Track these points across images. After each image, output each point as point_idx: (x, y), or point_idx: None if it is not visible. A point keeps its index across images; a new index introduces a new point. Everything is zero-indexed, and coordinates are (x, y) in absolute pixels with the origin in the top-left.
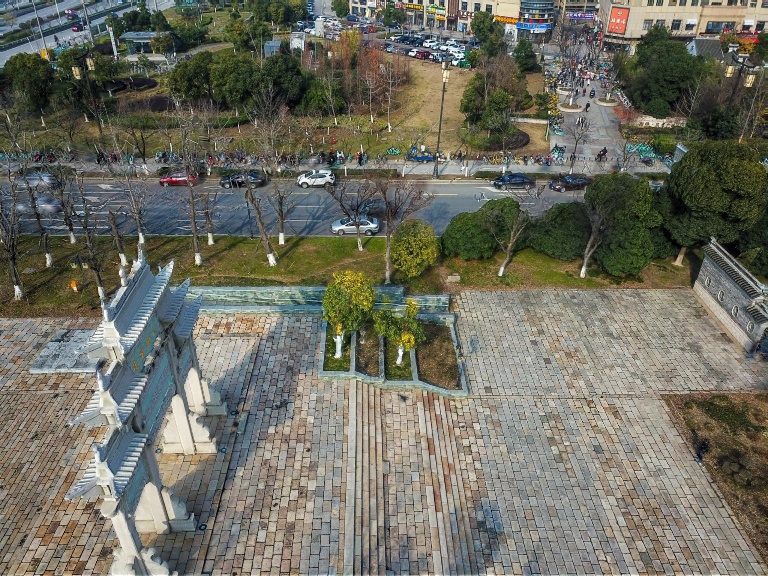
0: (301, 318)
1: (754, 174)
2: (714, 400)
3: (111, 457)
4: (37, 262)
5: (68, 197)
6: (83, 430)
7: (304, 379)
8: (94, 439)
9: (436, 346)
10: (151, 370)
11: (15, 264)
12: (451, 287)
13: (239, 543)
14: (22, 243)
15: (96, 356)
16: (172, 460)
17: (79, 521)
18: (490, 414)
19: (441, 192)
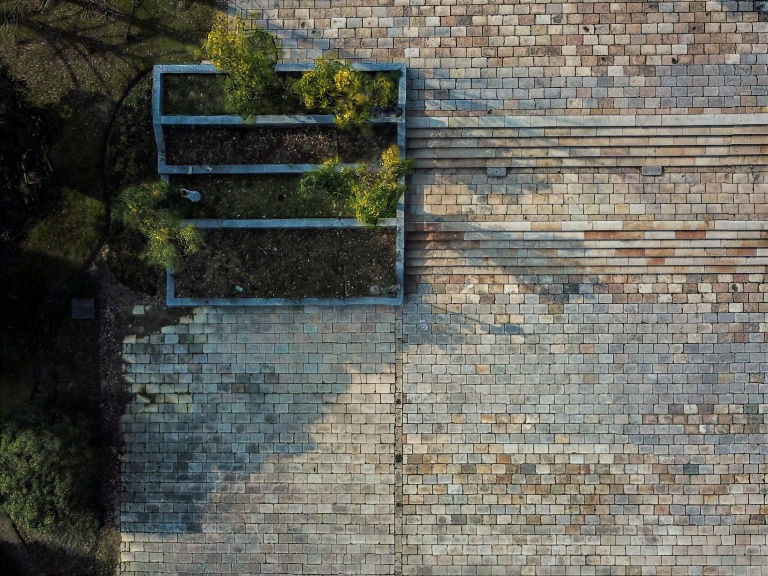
0: None
1: None
2: None
3: None
4: None
5: None
6: None
7: None
8: None
9: None
10: None
11: None
12: None
13: None
14: None
15: None
16: None
17: None
18: (760, 331)
19: None
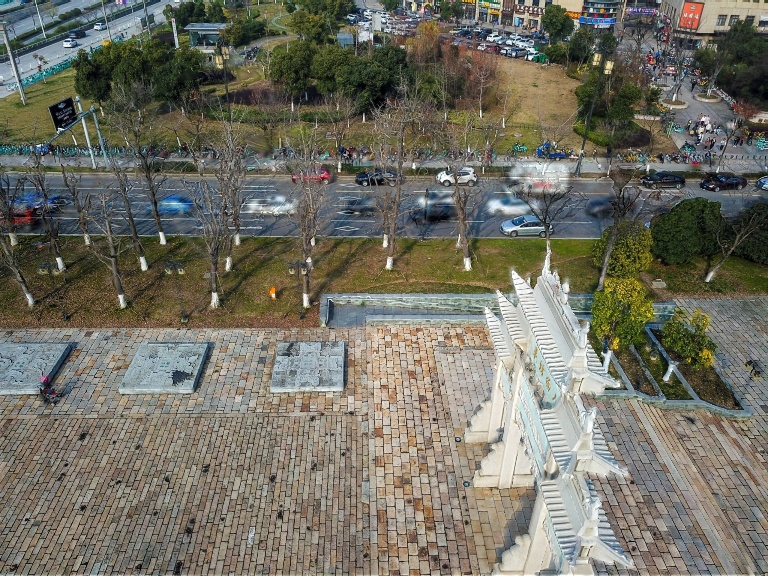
0: None
1: None
2: None
3: None
4: None
5: (238, 195)
6: (365, 459)
7: None
8: (384, 470)
9: None
10: None
11: (217, 269)
12: (660, 294)
13: None
14: (184, 245)
15: None
16: (488, 495)
17: (421, 570)
18: None
19: (591, 191)
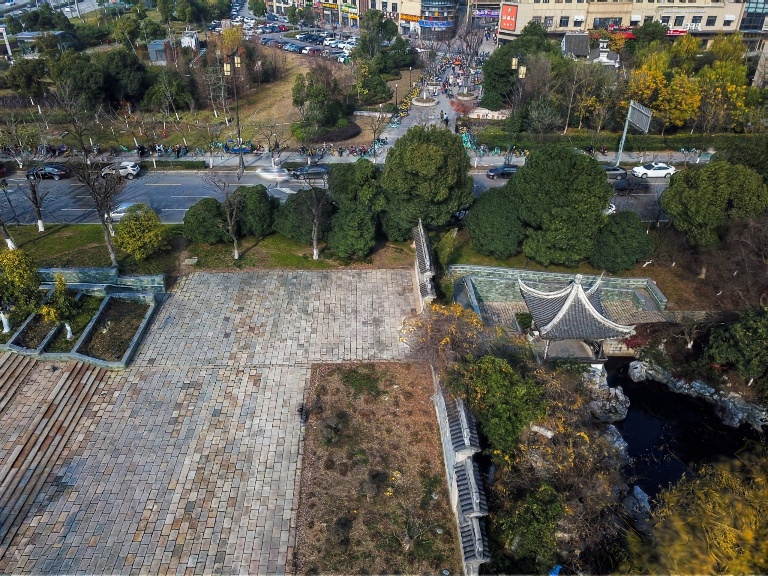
0: None
1: (426, 157)
2: (358, 368)
3: None
4: None
5: None
6: None
7: None
8: None
9: (123, 322)
10: None
11: None
12: (184, 269)
13: None
14: None
15: None
16: None
17: None
18: (137, 383)
19: (238, 182)
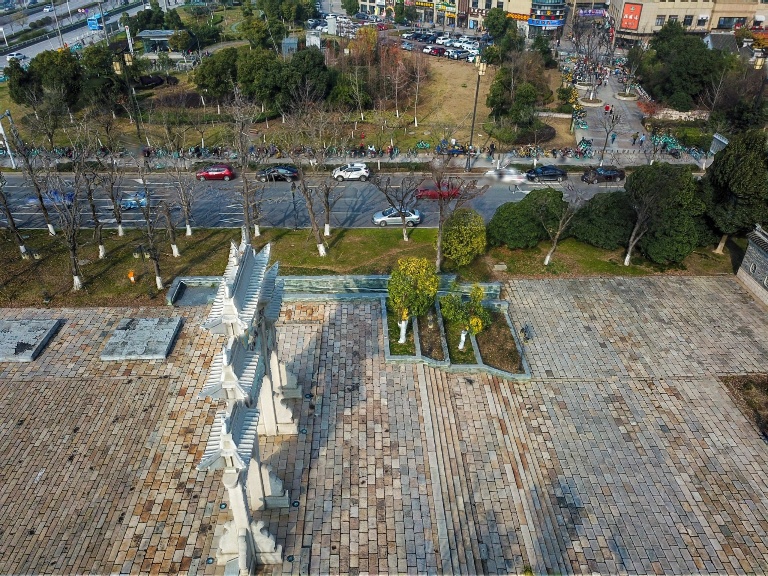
0: (359, 305)
1: None
2: None
3: (233, 430)
4: (89, 254)
5: (117, 190)
6: (162, 414)
7: (371, 363)
8: (175, 422)
9: (494, 332)
10: (253, 349)
11: (75, 255)
12: (499, 276)
13: (333, 519)
14: None
15: (216, 332)
16: None
17: (173, 499)
18: (555, 396)
19: None
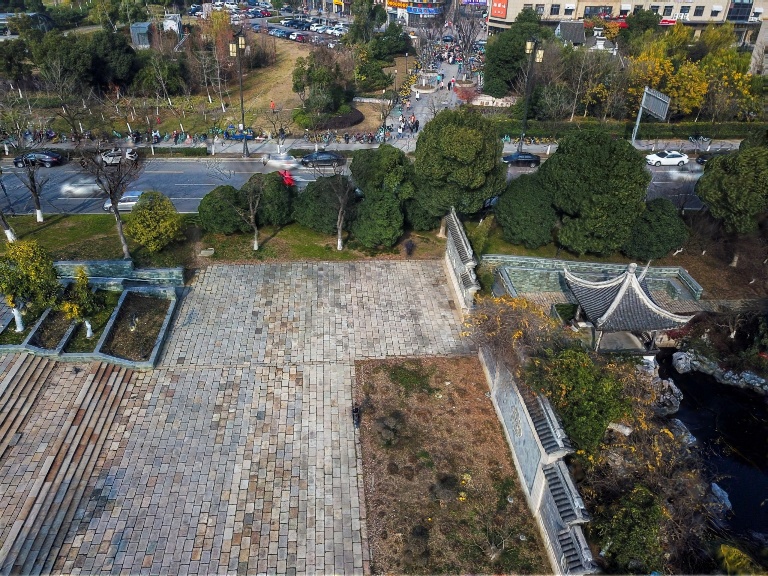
0: None
1: (467, 141)
2: (405, 364)
3: None
4: None
5: None
6: None
7: None
8: None
9: (145, 319)
10: None
11: None
12: (201, 261)
13: None
14: None
15: None
16: None
17: None
18: (169, 384)
19: (244, 170)
